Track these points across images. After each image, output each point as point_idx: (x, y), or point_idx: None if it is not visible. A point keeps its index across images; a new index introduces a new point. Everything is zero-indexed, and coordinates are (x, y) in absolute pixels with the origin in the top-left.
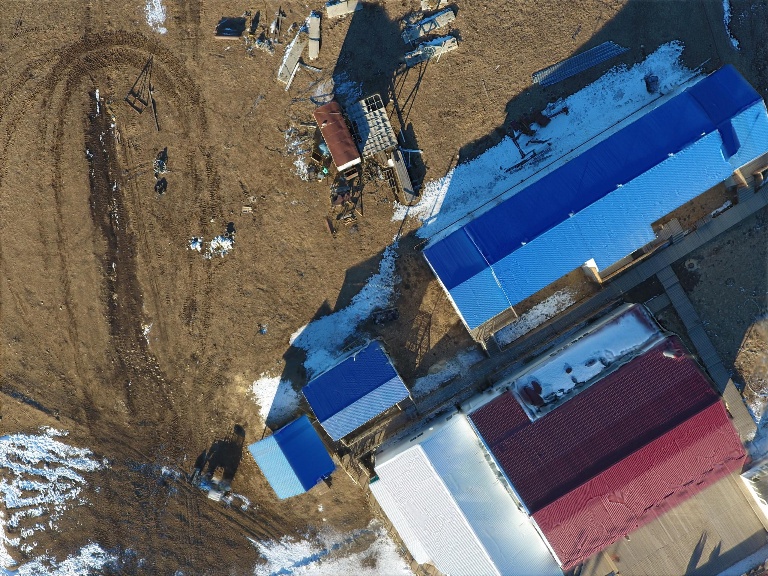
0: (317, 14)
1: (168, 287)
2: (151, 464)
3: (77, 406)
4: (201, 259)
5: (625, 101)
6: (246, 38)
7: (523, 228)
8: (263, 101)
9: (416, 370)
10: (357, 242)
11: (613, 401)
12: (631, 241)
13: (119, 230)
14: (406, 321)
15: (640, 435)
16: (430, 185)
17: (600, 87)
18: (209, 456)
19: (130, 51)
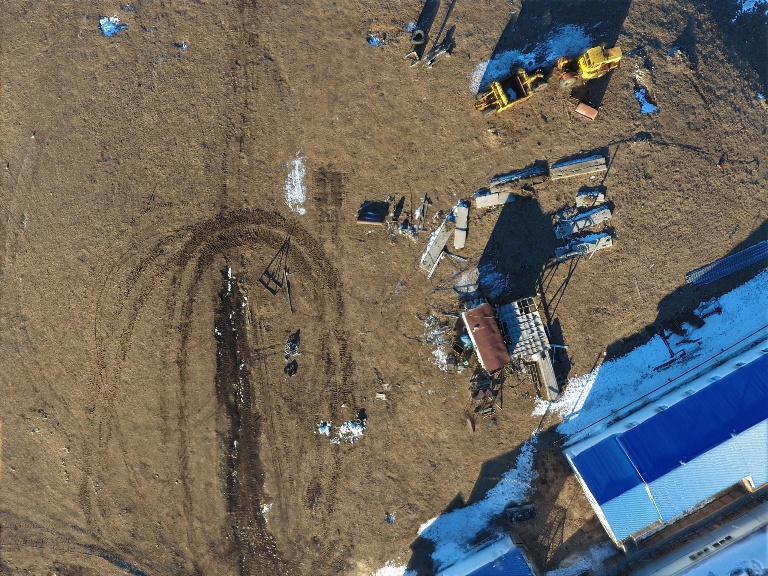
0: (465, 203)
1: (292, 469)
2: None
3: None
4: (329, 443)
5: None
6: (389, 223)
7: (681, 445)
8: (403, 288)
9: (547, 564)
10: (495, 436)
11: None
12: None
13: (243, 409)
14: (540, 516)
15: None
16: (574, 381)
17: (754, 286)
18: None
19: (266, 231)
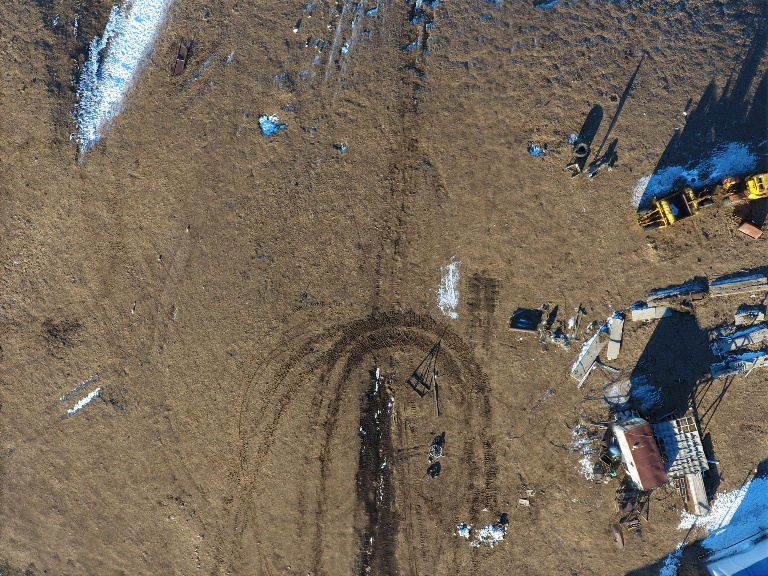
0: (620, 315)
1: (428, 569)
2: None
3: None
4: (468, 546)
5: None
6: (541, 331)
7: None
8: (552, 395)
9: None
10: (639, 547)
11: None
12: None
13: (382, 506)
14: None
15: None
16: (723, 497)
17: None
18: None
19: (417, 333)
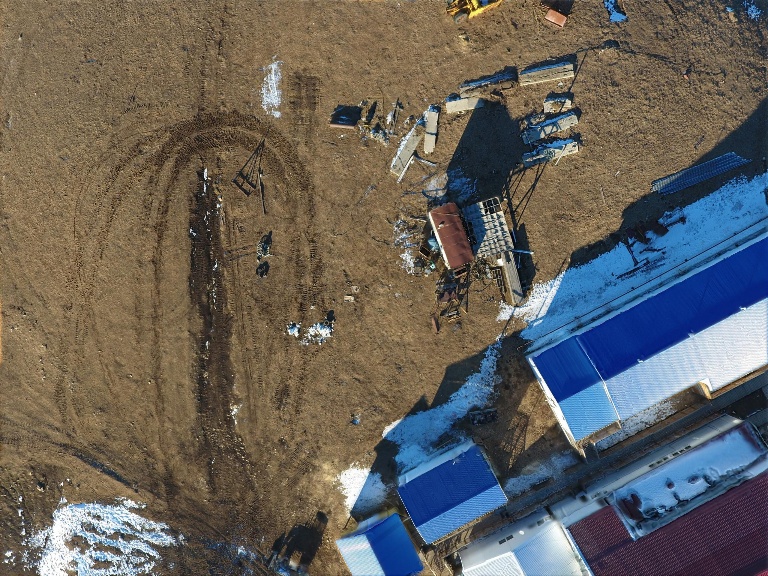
0: (435, 108)
1: (261, 370)
2: (228, 543)
3: (157, 480)
4: (298, 345)
5: (743, 213)
6: (361, 127)
7: (640, 344)
8: (373, 191)
9: (509, 471)
10: (460, 339)
11: (721, 526)
12: (748, 362)
13: (216, 309)
14: (503, 421)
15: (749, 565)
16: (539, 287)
17: (719, 198)
18: (288, 540)
19: (242, 133)
